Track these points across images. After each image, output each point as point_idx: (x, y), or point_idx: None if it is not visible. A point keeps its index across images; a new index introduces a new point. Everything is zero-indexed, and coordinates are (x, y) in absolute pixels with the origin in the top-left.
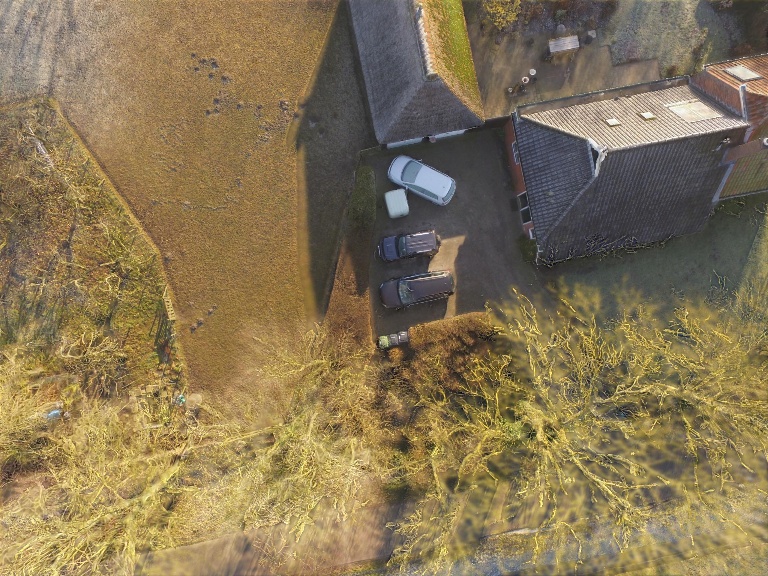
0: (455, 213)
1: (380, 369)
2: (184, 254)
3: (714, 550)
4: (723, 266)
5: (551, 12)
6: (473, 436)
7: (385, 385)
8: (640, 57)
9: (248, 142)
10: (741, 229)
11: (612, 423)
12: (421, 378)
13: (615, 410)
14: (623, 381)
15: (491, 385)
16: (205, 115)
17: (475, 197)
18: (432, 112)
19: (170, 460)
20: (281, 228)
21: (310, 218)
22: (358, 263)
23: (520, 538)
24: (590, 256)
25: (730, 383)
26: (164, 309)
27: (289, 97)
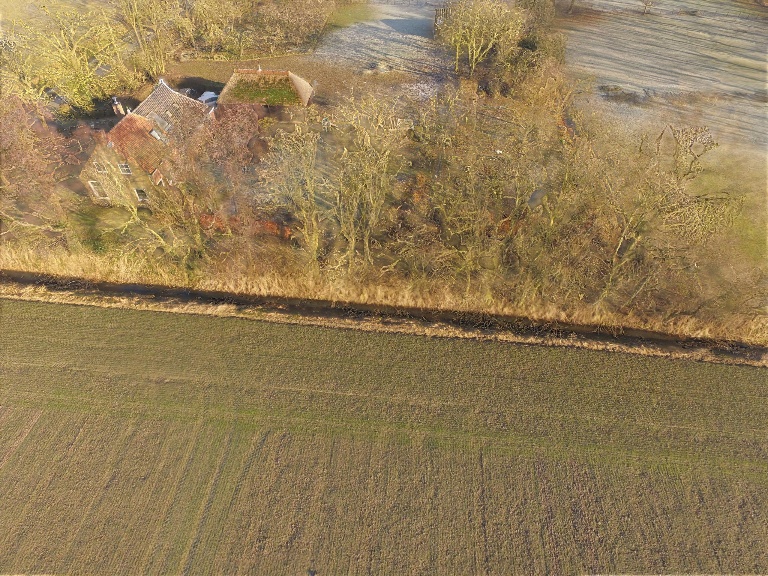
0: None
1: None
2: None
3: None
4: None
5: None
6: None
7: None
8: None
9: None
10: None
11: None
12: None
13: None
14: None
15: None
16: None
17: None
18: None
19: None
20: None
21: None
22: None
23: None
24: None
25: None
26: None
27: None
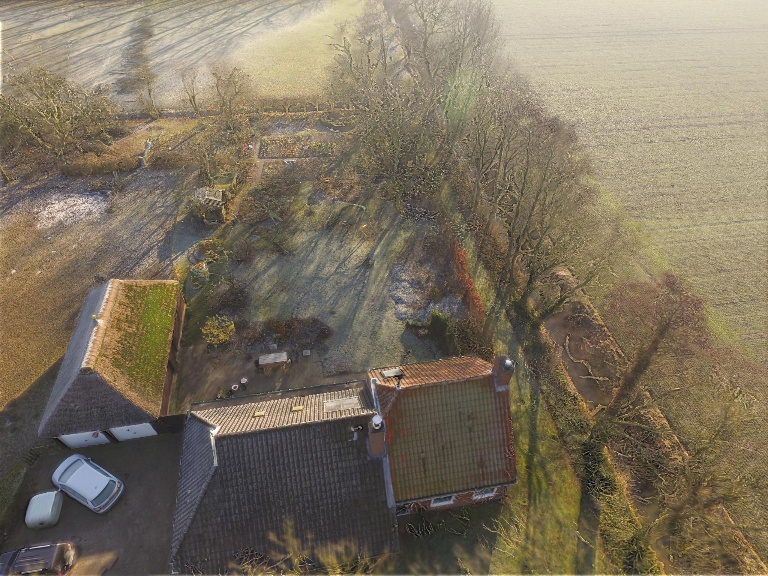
0: (117, 525)
1: None
2: None
3: None
4: None
5: None
6: None
7: None
8: (349, 370)
9: None
10: (469, 553)
11: None
12: None
13: None
14: None
15: None
16: None
17: (148, 505)
18: (92, 405)
19: None
20: None
21: None
22: None
23: None
24: None
25: None
26: None
27: (1, 399)
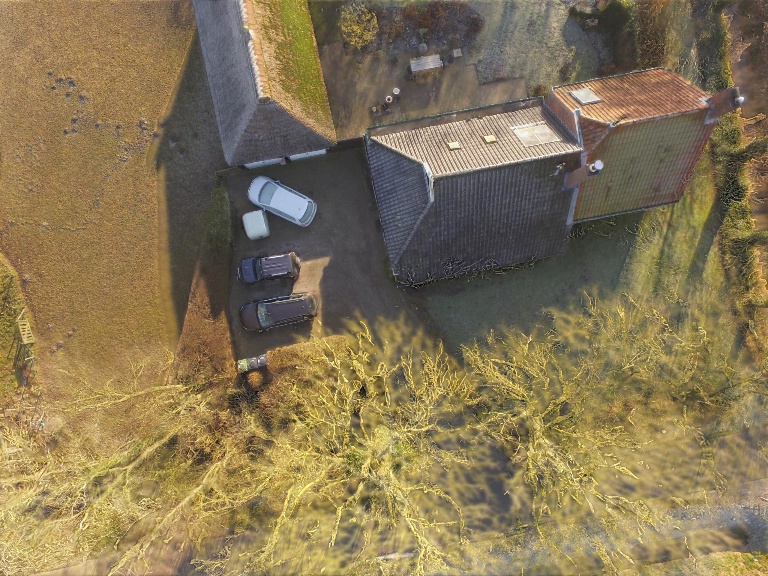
0: (319, 234)
1: (243, 392)
2: (42, 276)
3: (594, 573)
4: (594, 287)
5: (416, 30)
6: (262, 474)
7: (249, 409)
8: (506, 76)
9: (107, 162)
10: (612, 250)
11: (445, 453)
12: (277, 403)
13: (485, 433)
14: (493, 404)
15: (339, 411)
16: (63, 135)
17: (340, 218)
18: (275, 134)
19: (29, 485)
20: (142, 249)
21: (171, 239)
22: (212, 286)
23: (390, 563)
24: (457, 277)
25: (603, 405)
26: (18, 332)
27: (148, 116)
